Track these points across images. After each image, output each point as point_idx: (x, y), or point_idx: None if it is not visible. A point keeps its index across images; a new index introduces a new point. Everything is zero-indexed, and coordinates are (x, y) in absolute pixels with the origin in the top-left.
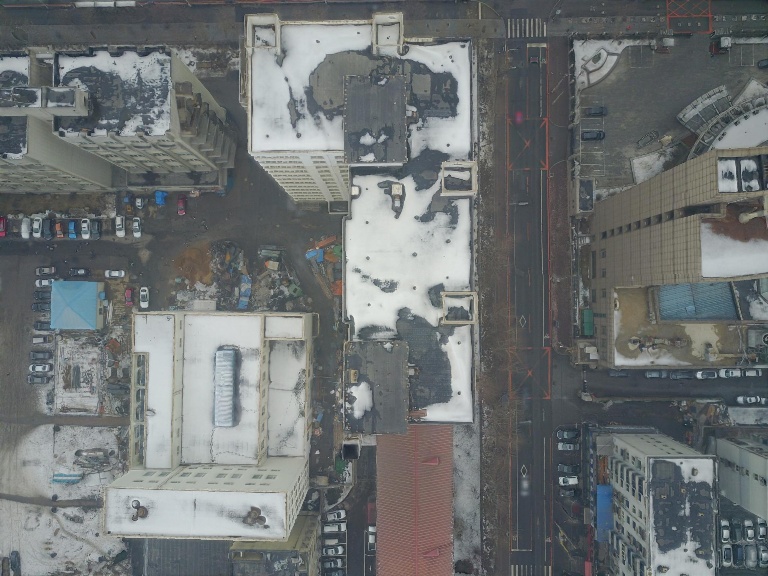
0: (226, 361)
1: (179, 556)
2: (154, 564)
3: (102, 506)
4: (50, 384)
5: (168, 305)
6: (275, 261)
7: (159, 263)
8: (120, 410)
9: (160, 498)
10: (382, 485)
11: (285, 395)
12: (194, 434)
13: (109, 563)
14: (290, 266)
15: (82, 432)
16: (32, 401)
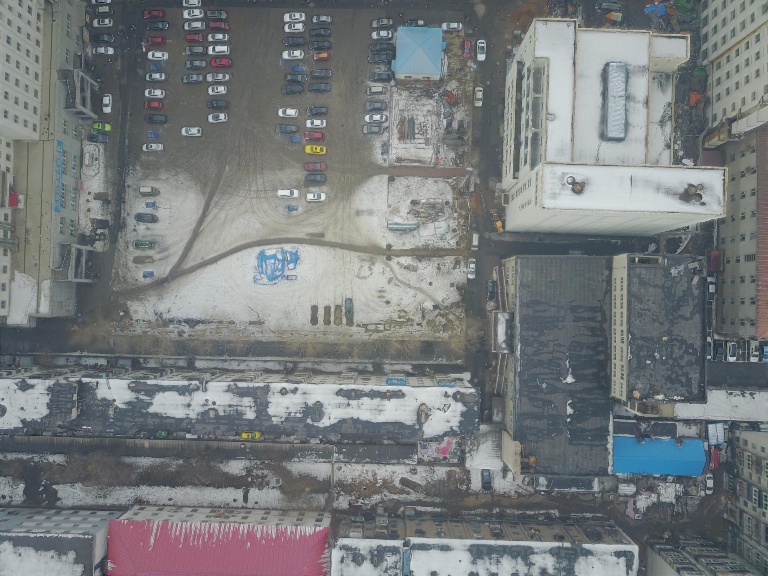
0: (618, 73)
1: (553, 276)
2: (526, 285)
3: (436, 256)
4: (384, 135)
5: (504, 59)
6: (618, 13)
7: (495, 18)
8: (455, 161)
9: (596, 174)
10: (764, 205)
11: (650, 127)
12: (580, 148)
13: (442, 312)
14: (628, 21)
15: (416, 183)
16: (366, 152)
